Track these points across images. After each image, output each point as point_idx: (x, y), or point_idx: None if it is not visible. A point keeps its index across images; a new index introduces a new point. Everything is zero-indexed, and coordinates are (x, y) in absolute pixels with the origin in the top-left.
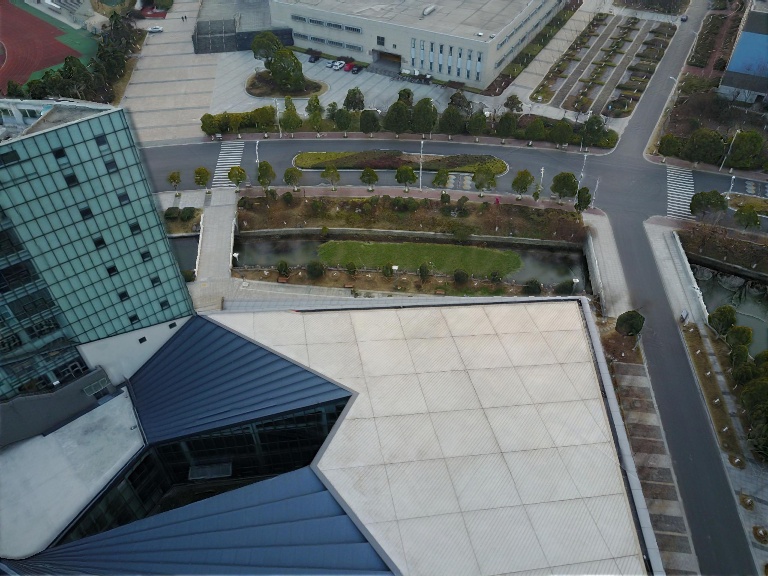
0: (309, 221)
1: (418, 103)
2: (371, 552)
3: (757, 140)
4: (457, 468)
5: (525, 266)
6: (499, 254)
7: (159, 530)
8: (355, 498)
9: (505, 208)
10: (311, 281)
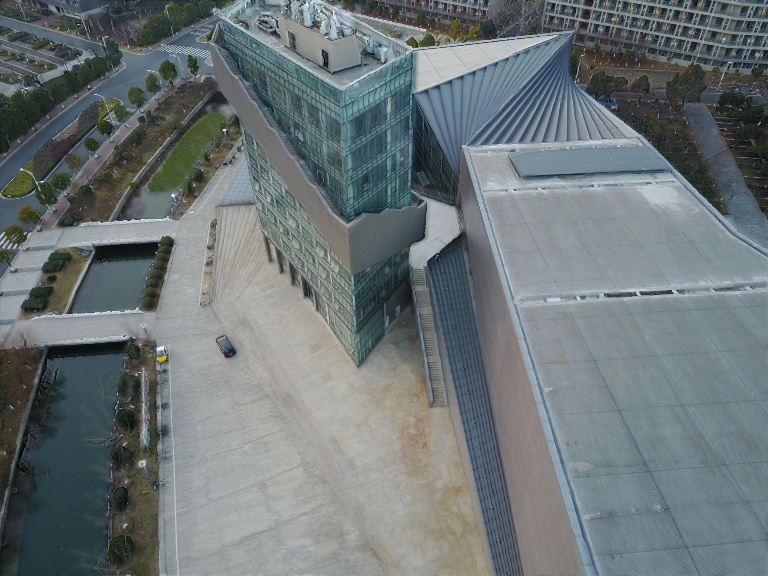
0: (117, 191)
1: (14, 101)
2: (456, 80)
3: (177, 6)
4: (413, 72)
5: (222, 111)
6: (205, 119)
7: (444, 132)
8: (431, 84)
9: (168, 102)
10: (203, 182)
